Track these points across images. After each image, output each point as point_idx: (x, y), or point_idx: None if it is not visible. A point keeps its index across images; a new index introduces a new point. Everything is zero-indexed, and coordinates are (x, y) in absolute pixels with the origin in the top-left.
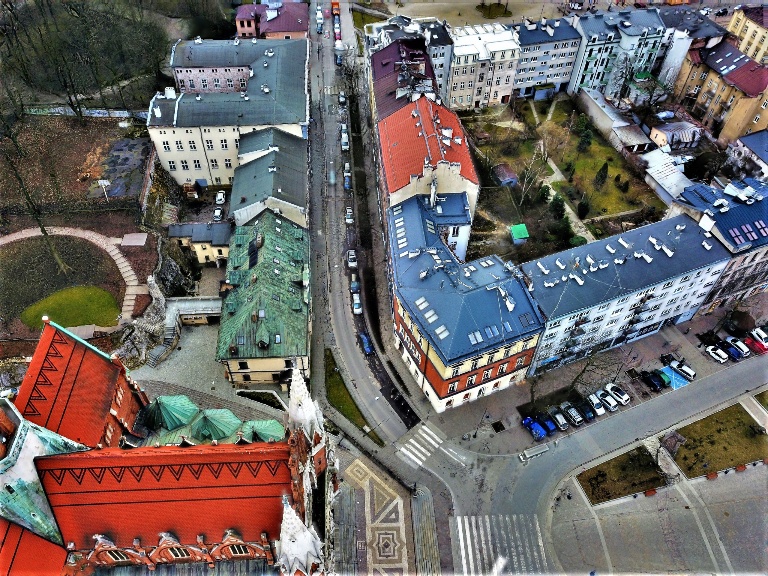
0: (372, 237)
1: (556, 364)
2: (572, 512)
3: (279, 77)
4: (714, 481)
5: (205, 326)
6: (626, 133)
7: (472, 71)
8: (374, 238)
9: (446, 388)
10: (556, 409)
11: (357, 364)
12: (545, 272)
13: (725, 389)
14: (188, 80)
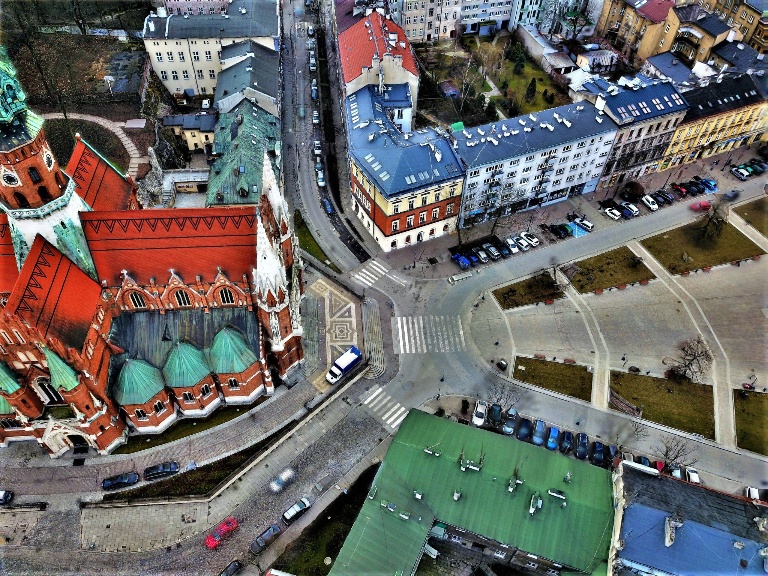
0: (335, 134)
1: (482, 219)
2: (487, 314)
3: (254, 2)
4: (600, 295)
5: (196, 193)
6: (555, 58)
7: (423, 6)
8: (336, 134)
9: (390, 226)
10: (479, 248)
11: (321, 220)
12: (468, 137)
13: (617, 237)
14: (176, 8)
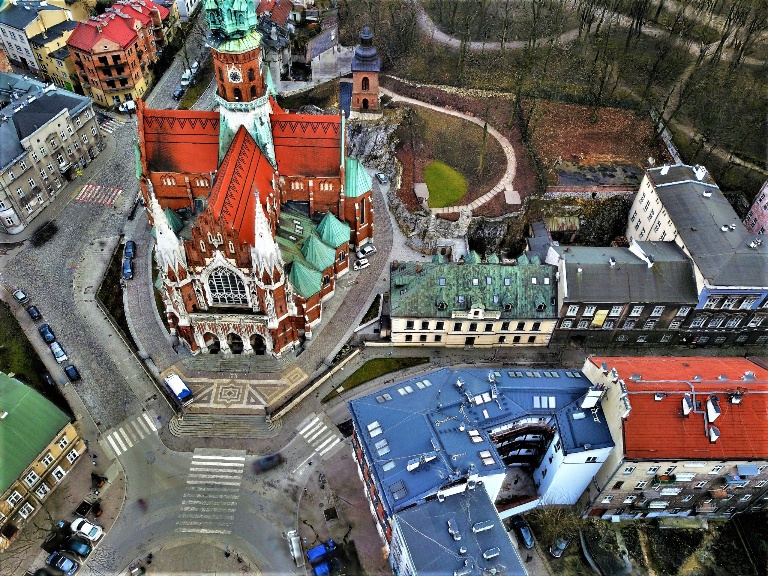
0: None
1: None
2: (225, 574)
3: None
4: None
5: None
6: None
7: None
8: None
9: None
10: None
11: None
12: None
13: None
14: (767, 199)
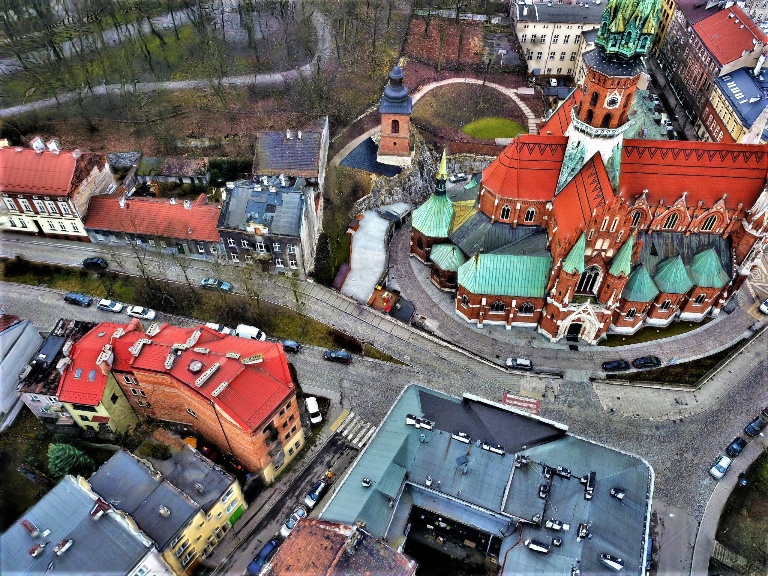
0: (676, 114)
1: None
2: None
3: None
4: None
5: None
6: None
7: None
8: (678, 115)
9: None
10: None
11: None
12: None
13: None
14: None
